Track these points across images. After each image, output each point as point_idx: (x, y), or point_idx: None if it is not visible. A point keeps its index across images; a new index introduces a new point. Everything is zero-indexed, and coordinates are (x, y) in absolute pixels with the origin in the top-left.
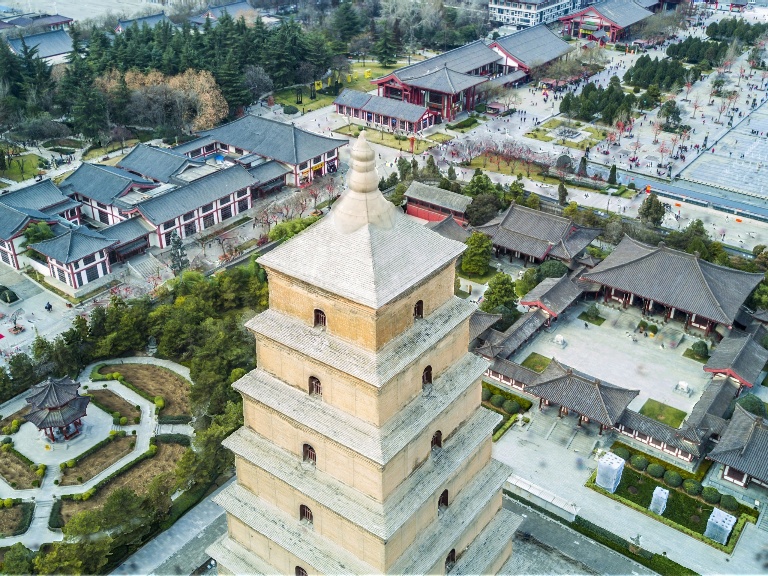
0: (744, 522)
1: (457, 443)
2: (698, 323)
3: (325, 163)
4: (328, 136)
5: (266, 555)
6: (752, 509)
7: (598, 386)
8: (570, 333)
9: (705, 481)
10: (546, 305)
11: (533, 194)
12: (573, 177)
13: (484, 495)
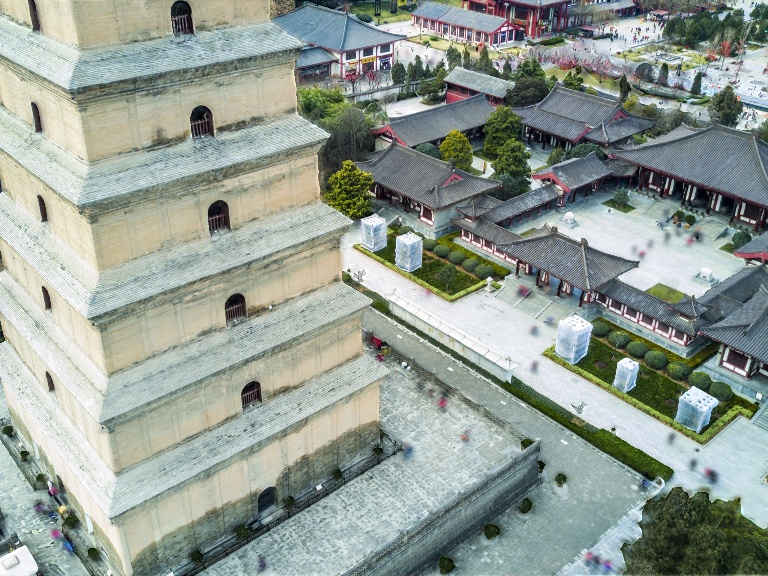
0: (735, 414)
1: (242, 139)
2: (748, 217)
3: (377, 58)
4: (384, 30)
5: (24, 281)
6: (751, 403)
7: (584, 247)
8: (586, 216)
9: (699, 369)
10: (559, 178)
11: (590, 88)
12: (651, 86)
13: (294, 235)
